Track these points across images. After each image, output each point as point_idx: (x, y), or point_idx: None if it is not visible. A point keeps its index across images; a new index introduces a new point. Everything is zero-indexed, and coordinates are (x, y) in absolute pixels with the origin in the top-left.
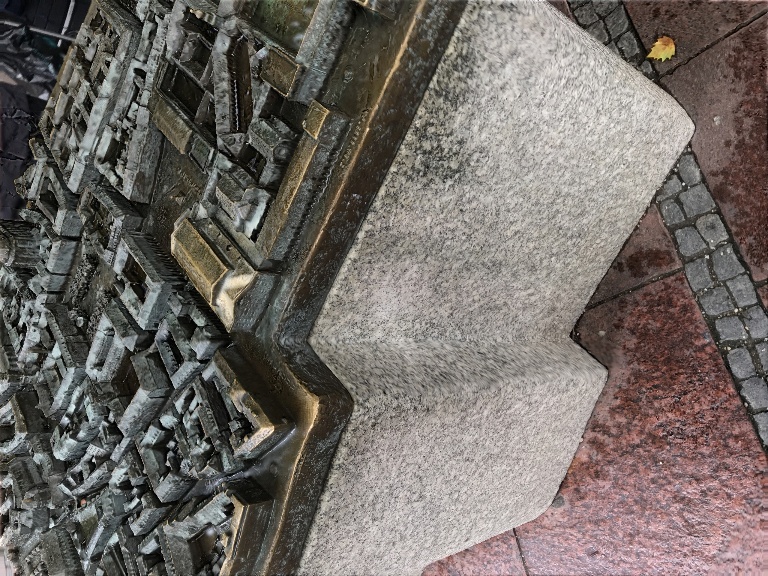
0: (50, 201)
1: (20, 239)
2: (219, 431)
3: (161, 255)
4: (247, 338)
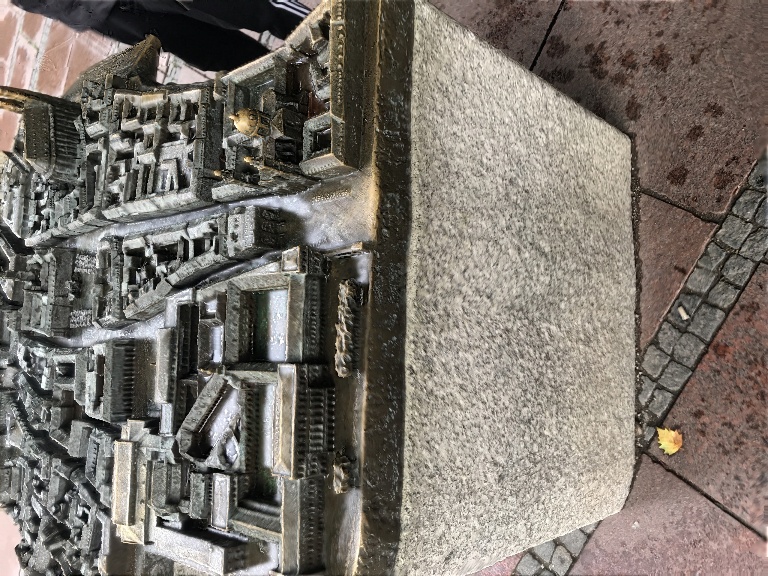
0: (97, 161)
1: (61, 164)
2: (89, 551)
3: (128, 377)
4: None
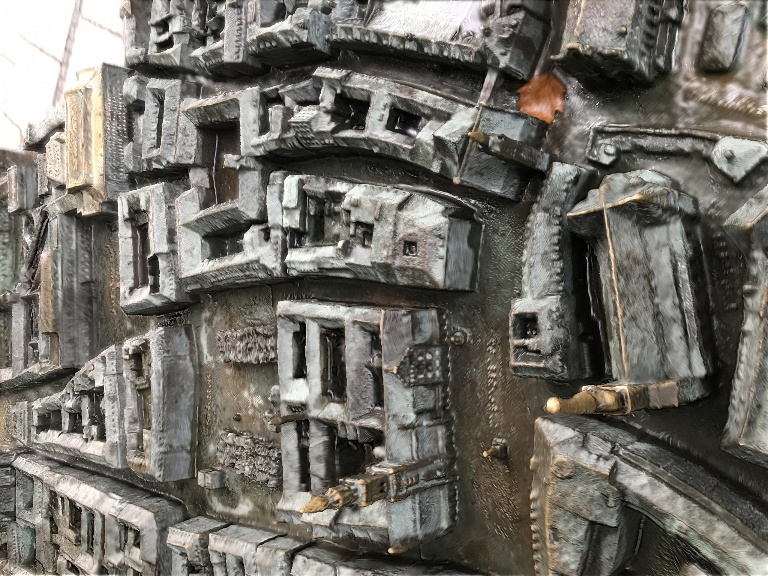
0: None
1: None
2: None
3: None
4: None
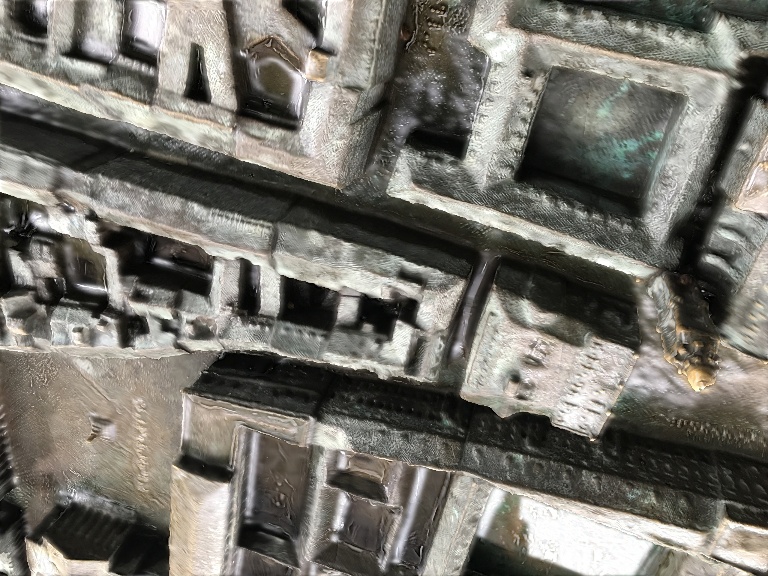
0: None
1: None
2: None
3: None
4: None
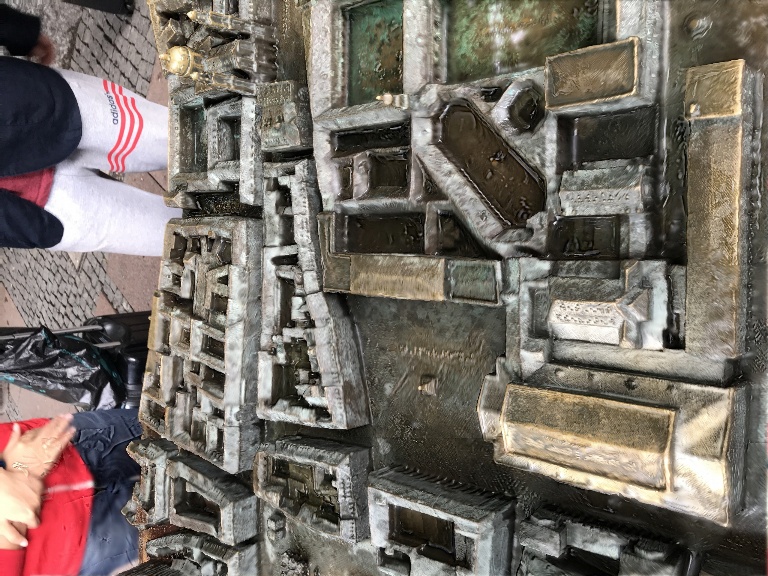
0: (190, 509)
1: None
2: None
3: (440, 482)
4: (721, 527)
